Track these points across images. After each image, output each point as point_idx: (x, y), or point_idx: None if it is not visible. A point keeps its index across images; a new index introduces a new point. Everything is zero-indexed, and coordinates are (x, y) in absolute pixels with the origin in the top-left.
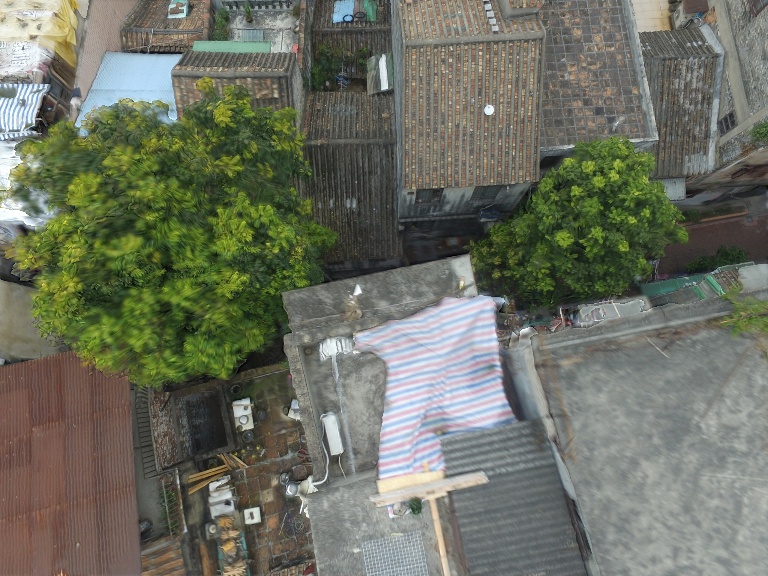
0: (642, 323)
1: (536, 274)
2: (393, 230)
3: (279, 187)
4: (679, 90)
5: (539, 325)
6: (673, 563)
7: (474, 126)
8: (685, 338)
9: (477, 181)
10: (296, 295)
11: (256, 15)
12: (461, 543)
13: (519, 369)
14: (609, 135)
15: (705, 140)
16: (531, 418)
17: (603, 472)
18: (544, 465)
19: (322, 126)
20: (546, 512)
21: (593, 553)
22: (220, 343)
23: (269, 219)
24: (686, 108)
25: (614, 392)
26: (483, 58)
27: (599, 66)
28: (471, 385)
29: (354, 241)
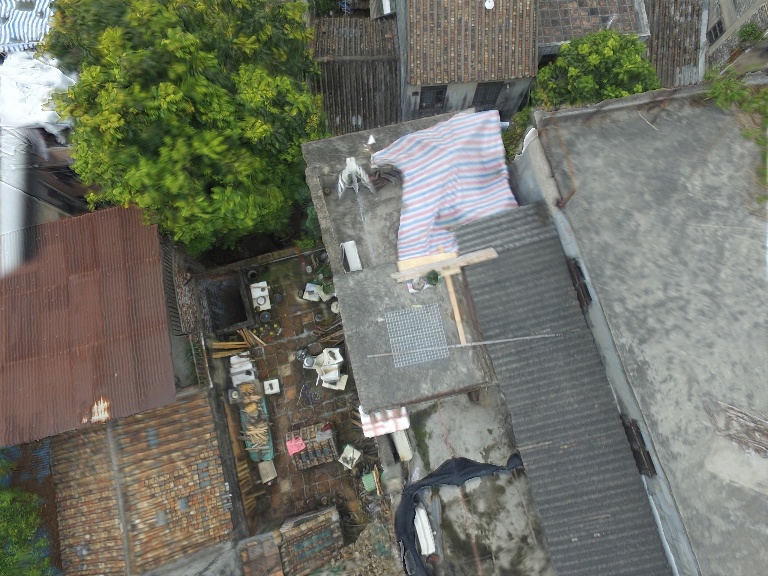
0: None
1: None
2: None
3: (291, 78)
4: (670, 2)
5: None
6: (663, 294)
7: (475, 21)
8: (672, 114)
9: (479, 76)
10: (314, 146)
11: None
12: (474, 311)
13: (524, 170)
14: None
15: (695, 51)
16: (535, 201)
17: (600, 221)
18: (548, 238)
19: (328, 46)
20: (550, 278)
21: (592, 285)
22: (244, 192)
23: (286, 88)
24: (677, 19)
25: (610, 157)
26: None
27: None
28: (480, 187)
29: None
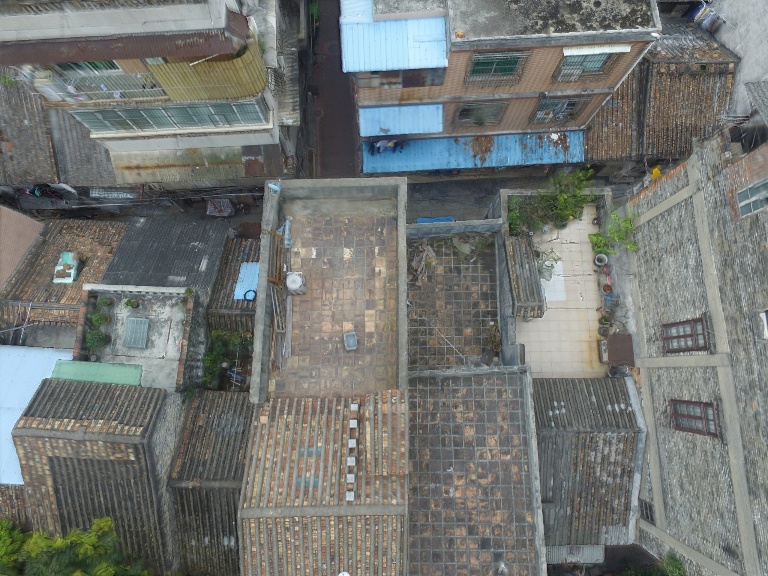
0: None
1: None
2: None
3: None
4: (596, 462)
5: None
6: None
7: None
8: None
9: None
10: None
11: (143, 298)
12: None
13: None
14: None
15: (625, 512)
16: None
17: None
18: None
19: (200, 453)
20: None
21: None
22: None
23: None
24: (603, 480)
25: None
26: (335, 528)
27: (491, 480)
28: None
29: (233, 575)
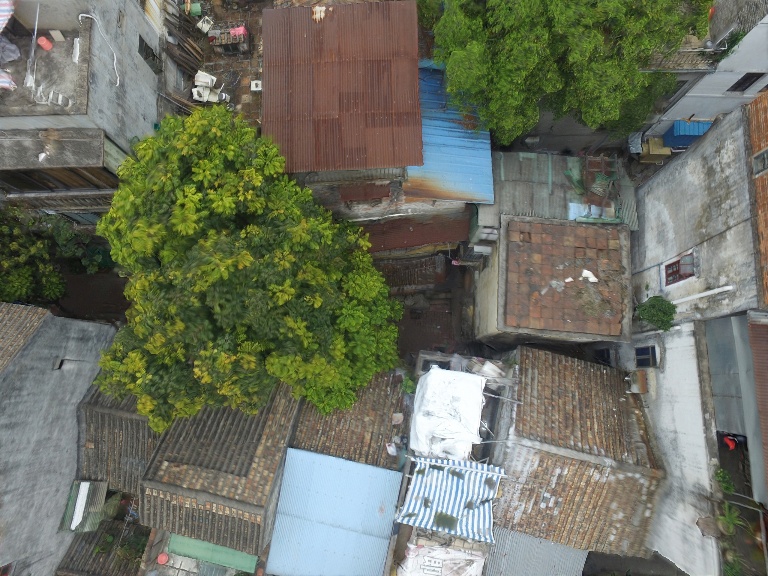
0: None
1: None
2: None
3: None
4: None
5: None
6: None
7: None
8: None
9: None
10: (91, 162)
11: None
12: None
13: None
14: None
15: None
16: None
17: None
18: None
19: None
20: None
21: None
22: None
23: (115, 246)
24: None
25: None
26: None
27: None
28: None
29: None
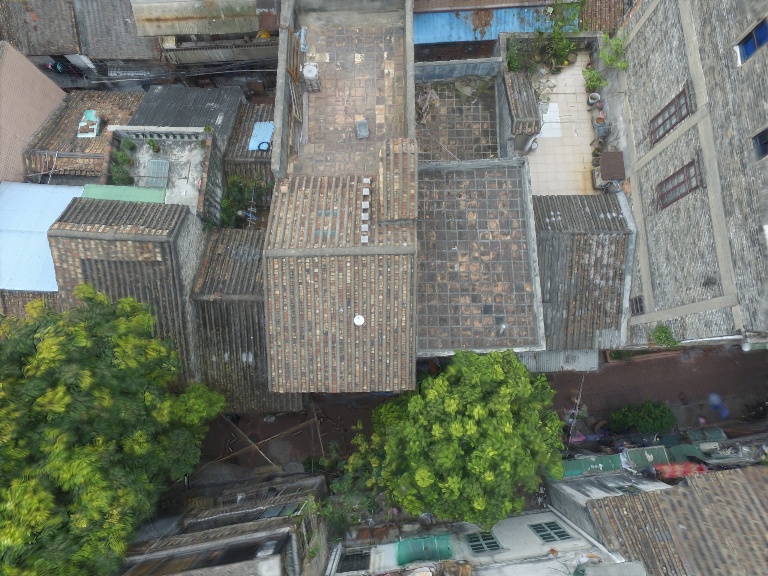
0: None
1: (401, 500)
2: None
3: (127, 398)
4: (589, 265)
5: (410, 544)
6: None
7: (344, 334)
8: None
9: (349, 387)
10: None
11: (164, 144)
12: None
13: None
14: (496, 338)
15: (617, 315)
16: None
17: None
18: None
19: (220, 275)
20: None
21: None
22: None
23: (80, 481)
24: (597, 283)
25: None
26: (351, 270)
27: (492, 257)
28: None
29: (251, 394)
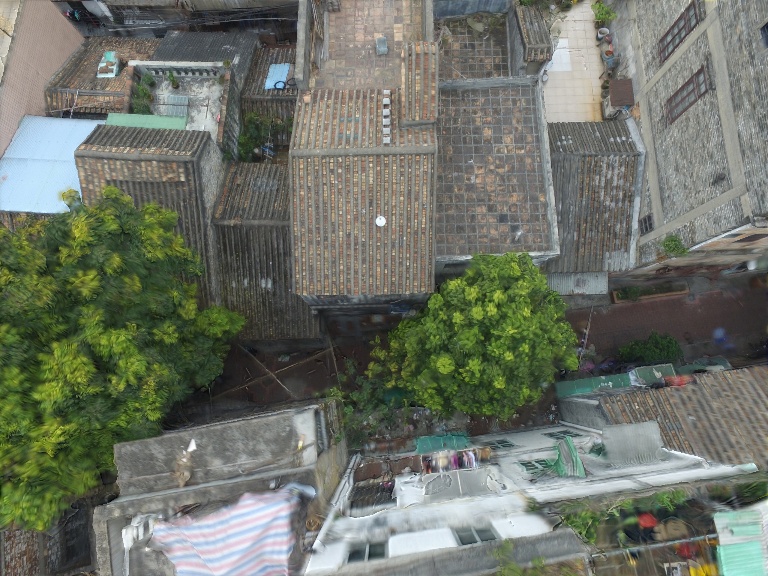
0: (409, 575)
1: (422, 394)
2: (309, 311)
3: (158, 295)
4: (600, 187)
5: (429, 441)
6: None
7: (366, 236)
8: None
9: (370, 290)
10: (128, 448)
11: (183, 81)
12: None
13: None
14: (511, 245)
15: (626, 237)
16: None
17: None
18: None
19: (239, 203)
20: None
21: None
22: (47, 495)
23: (120, 352)
24: (607, 205)
25: None
26: (373, 170)
27: (507, 170)
28: None
29: (269, 320)
